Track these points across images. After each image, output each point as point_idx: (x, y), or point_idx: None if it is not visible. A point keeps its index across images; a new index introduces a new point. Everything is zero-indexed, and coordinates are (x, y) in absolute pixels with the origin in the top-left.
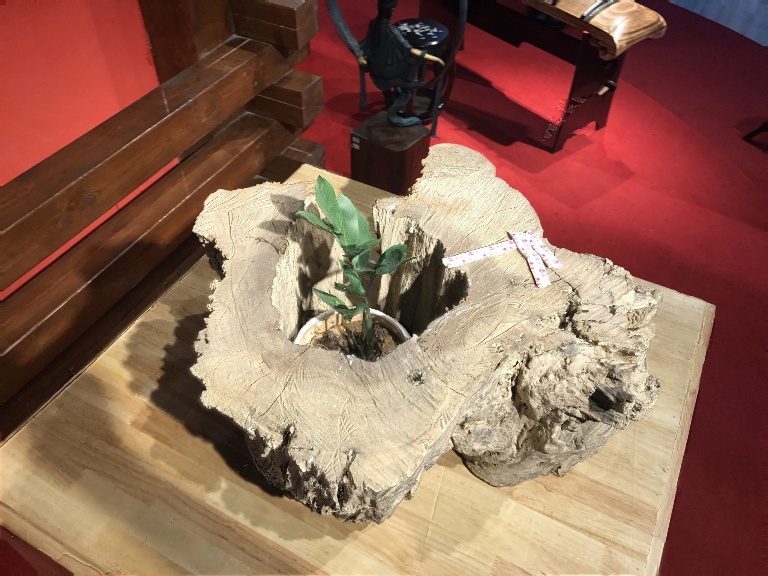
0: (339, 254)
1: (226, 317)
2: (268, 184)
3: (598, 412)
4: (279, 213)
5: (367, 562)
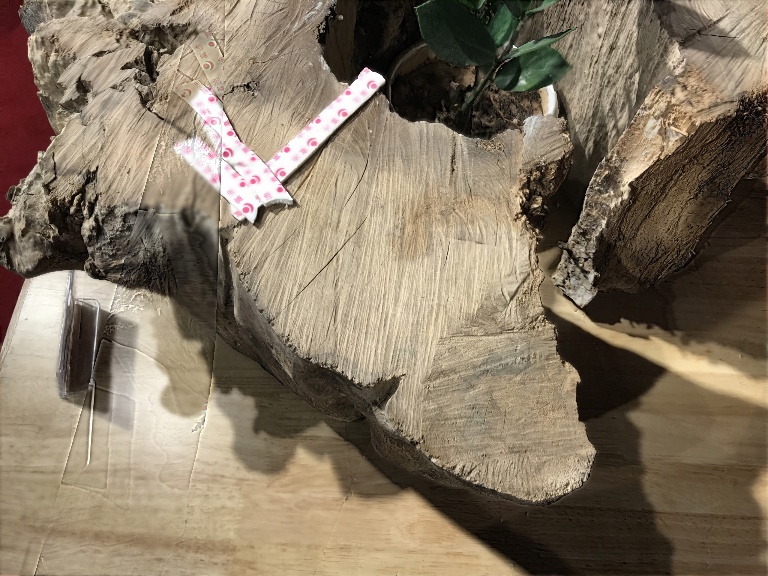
0: None
1: None
2: None
3: None
4: (692, 7)
5: None
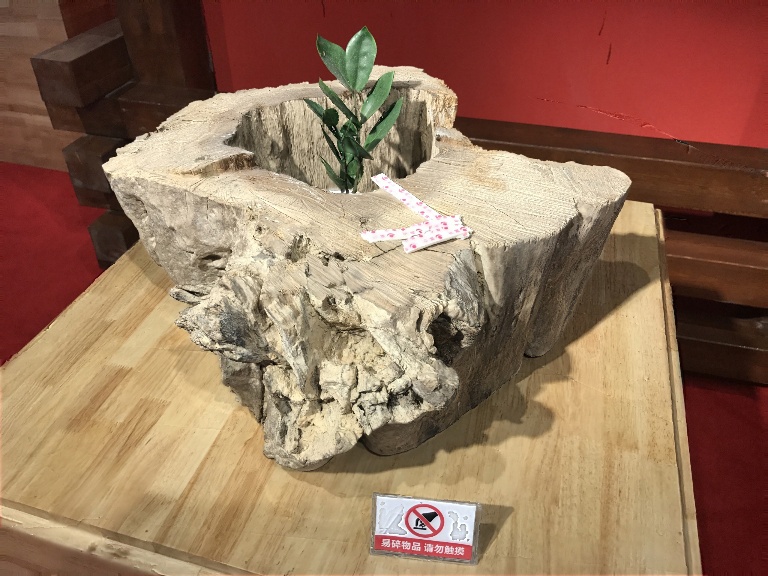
0: None
1: (269, 92)
2: (440, 81)
3: None
4: None
5: (171, 318)
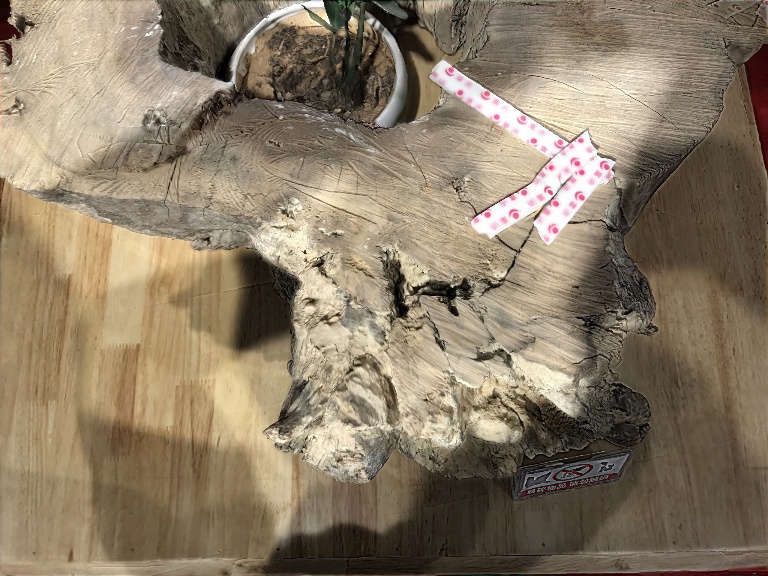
0: None
1: None
2: None
3: (291, 400)
4: None
5: (143, 249)
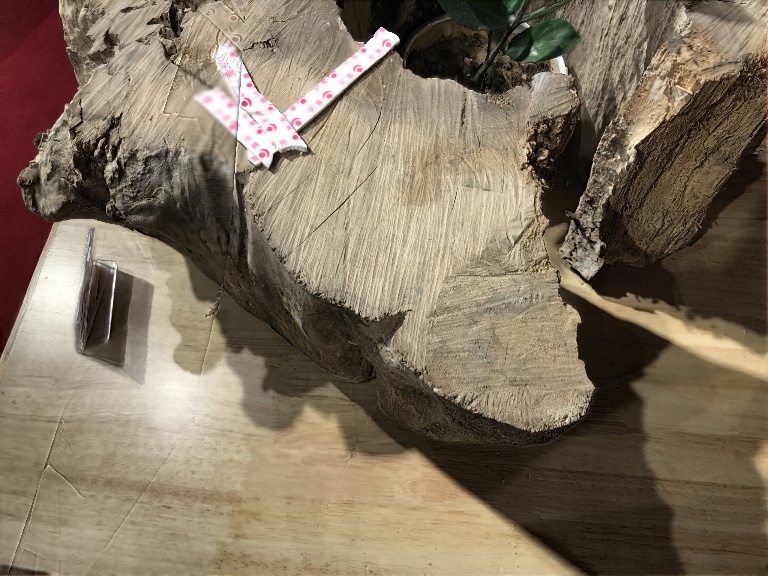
0: None
1: None
2: None
3: None
4: None
5: None
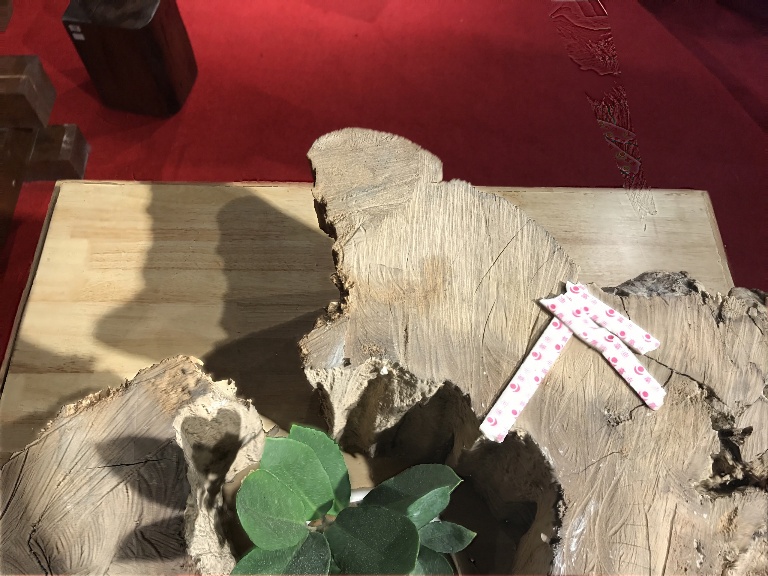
0: (253, 426)
1: None
2: (71, 411)
3: None
4: (142, 501)
5: None
